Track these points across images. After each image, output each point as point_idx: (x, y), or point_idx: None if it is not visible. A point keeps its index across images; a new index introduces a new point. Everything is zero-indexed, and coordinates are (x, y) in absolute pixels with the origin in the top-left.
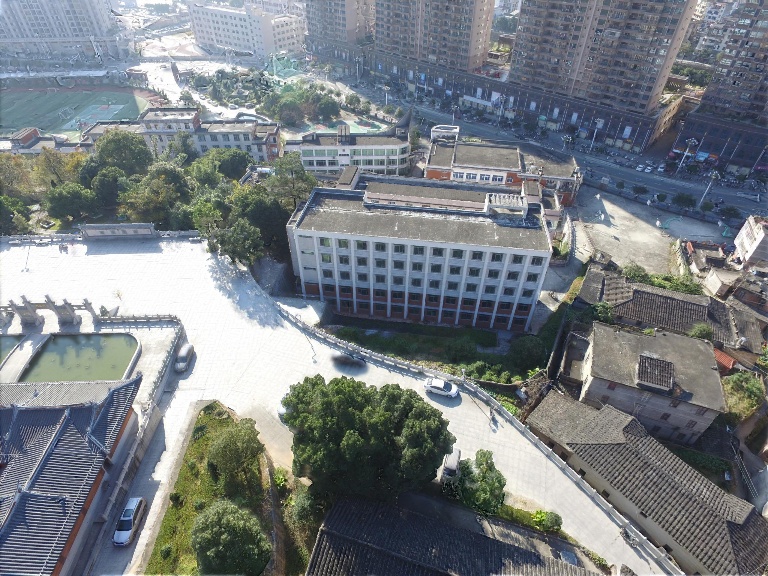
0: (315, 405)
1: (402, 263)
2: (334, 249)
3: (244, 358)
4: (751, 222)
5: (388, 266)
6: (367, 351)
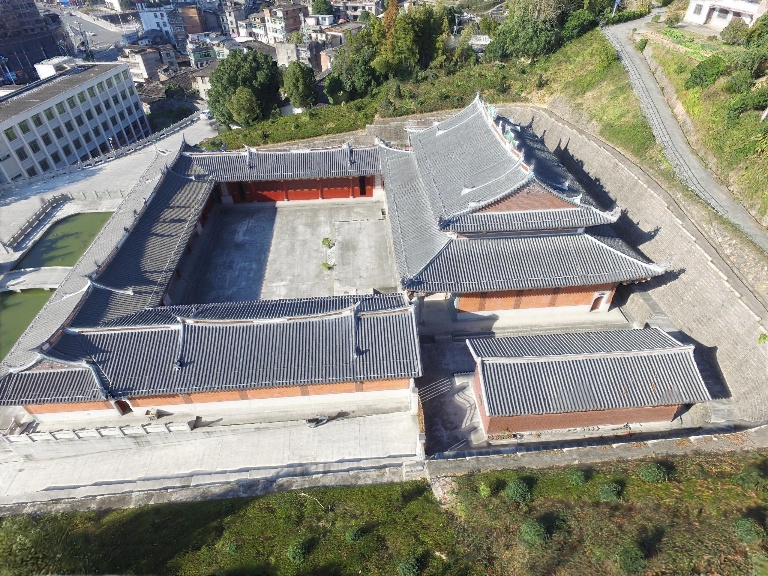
0: (239, 57)
1: (69, 124)
2: (22, 138)
3: (133, 176)
4: (123, 60)
5: (65, 132)
6: (163, 131)
